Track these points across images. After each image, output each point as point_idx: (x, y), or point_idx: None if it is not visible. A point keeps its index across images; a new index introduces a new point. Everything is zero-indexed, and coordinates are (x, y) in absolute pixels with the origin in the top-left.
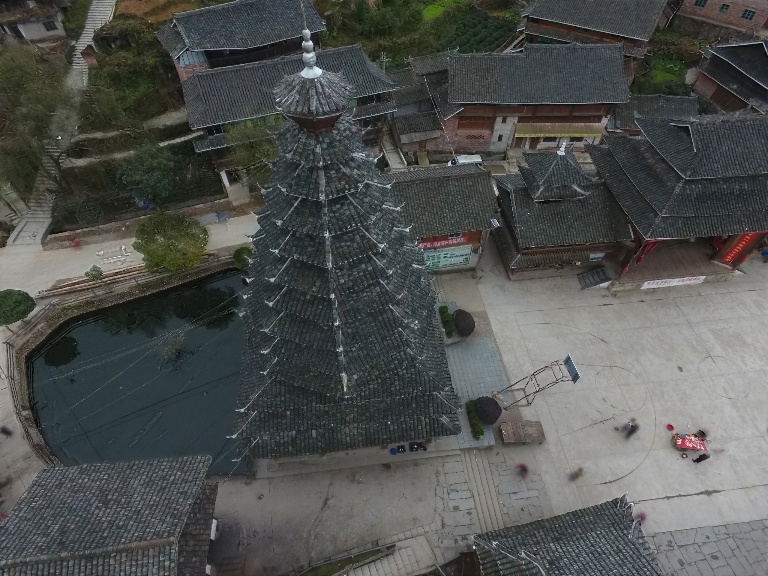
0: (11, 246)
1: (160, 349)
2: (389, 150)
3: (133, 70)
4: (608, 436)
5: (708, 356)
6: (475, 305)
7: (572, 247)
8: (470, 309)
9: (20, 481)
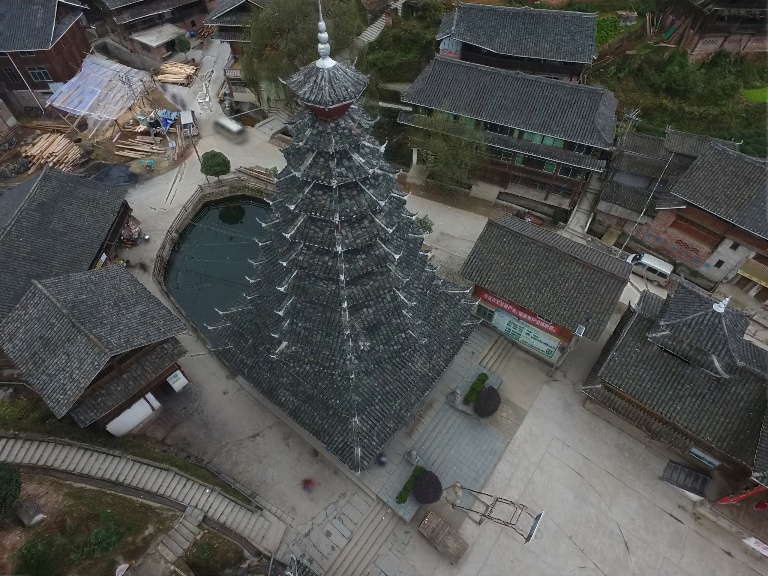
0: (256, 129)
1: None
2: (583, 209)
3: (413, 39)
4: None
5: None
6: (523, 399)
7: (672, 422)
8: (514, 398)
9: (138, 271)
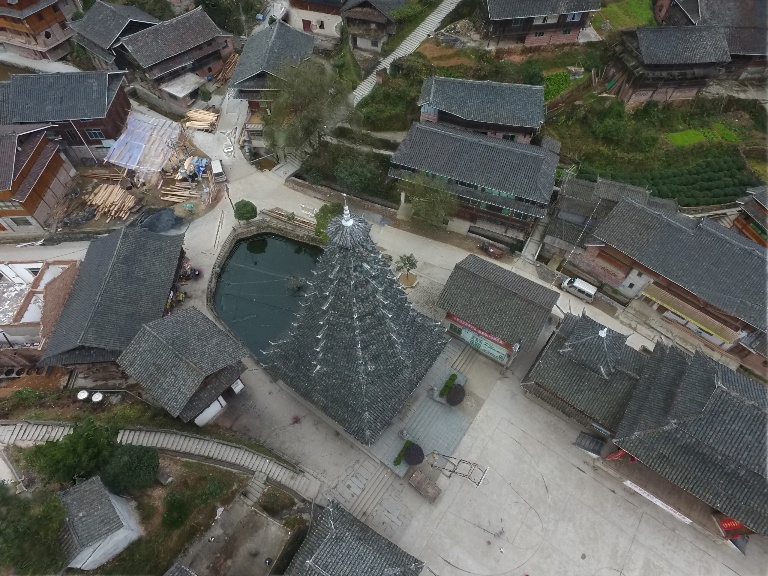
0: (272, 172)
1: (290, 280)
2: (534, 240)
3: (400, 95)
4: (479, 541)
5: (619, 570)
6: (482, 391)
7: None
8: (476, 391)
9: (194, 301)
